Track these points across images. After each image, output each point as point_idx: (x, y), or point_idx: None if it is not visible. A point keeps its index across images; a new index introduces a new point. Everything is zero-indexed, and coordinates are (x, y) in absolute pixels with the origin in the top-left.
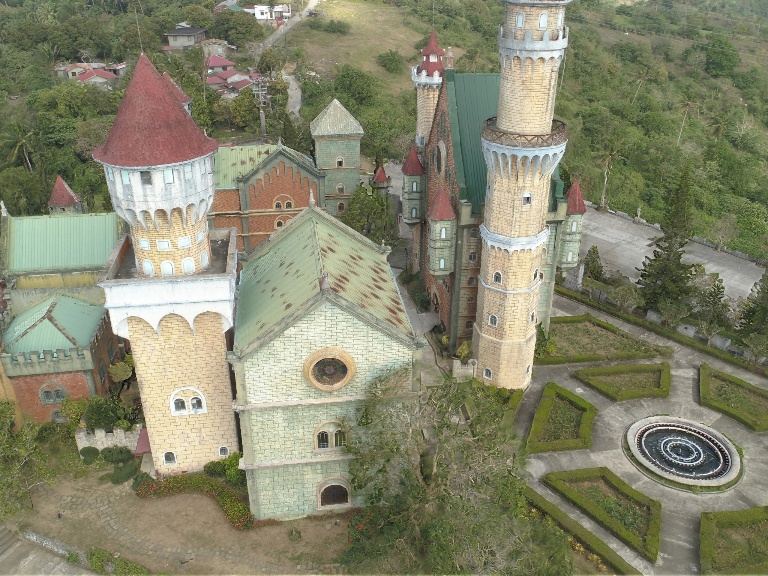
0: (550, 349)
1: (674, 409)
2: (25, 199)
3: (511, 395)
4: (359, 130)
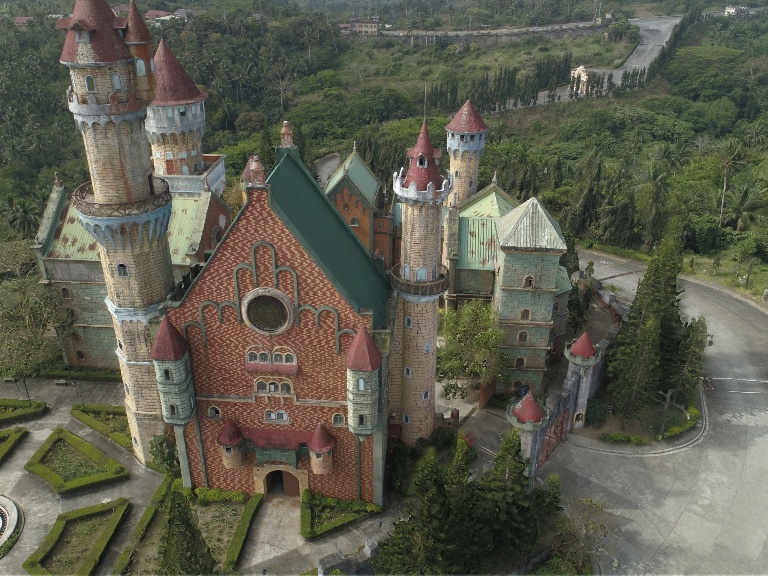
0: (173, 485)
1: (9, 571)
2: (608, 207)
3: (129, 437)
4: (503, 240)
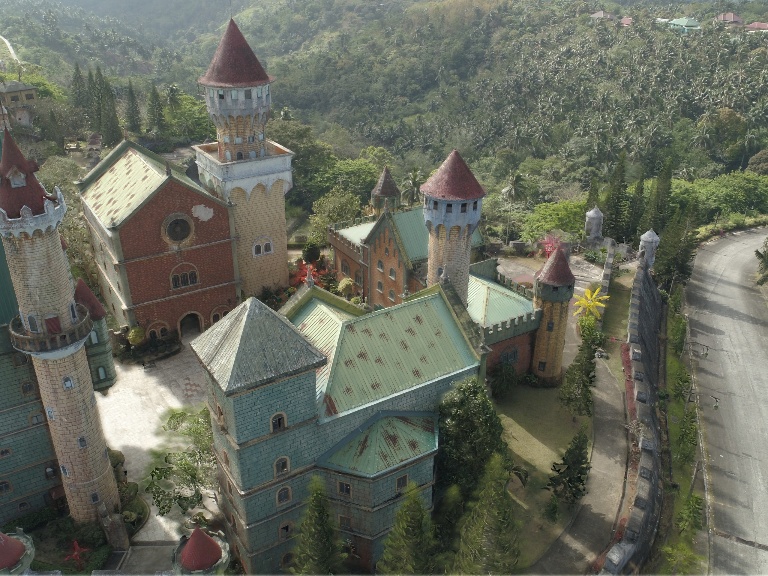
0: None
1: None
2: None
3: None
4: None
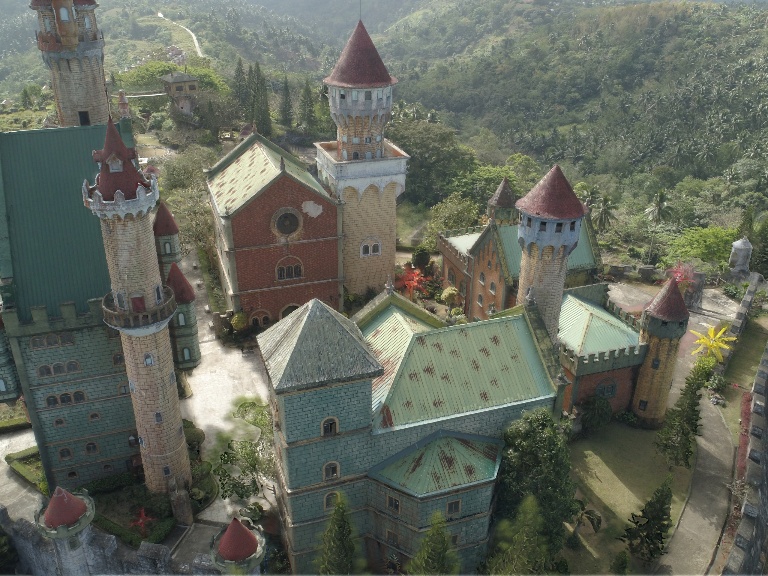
0: None
1: None
2: None
3: None
4: None
